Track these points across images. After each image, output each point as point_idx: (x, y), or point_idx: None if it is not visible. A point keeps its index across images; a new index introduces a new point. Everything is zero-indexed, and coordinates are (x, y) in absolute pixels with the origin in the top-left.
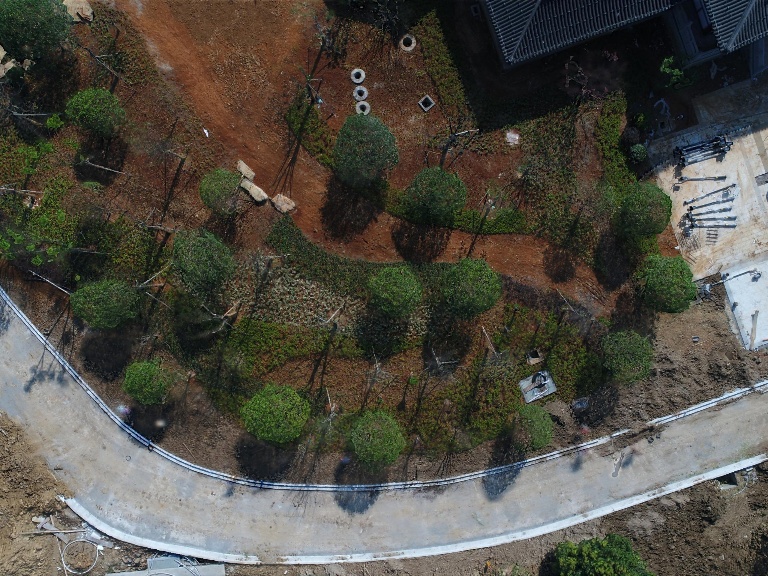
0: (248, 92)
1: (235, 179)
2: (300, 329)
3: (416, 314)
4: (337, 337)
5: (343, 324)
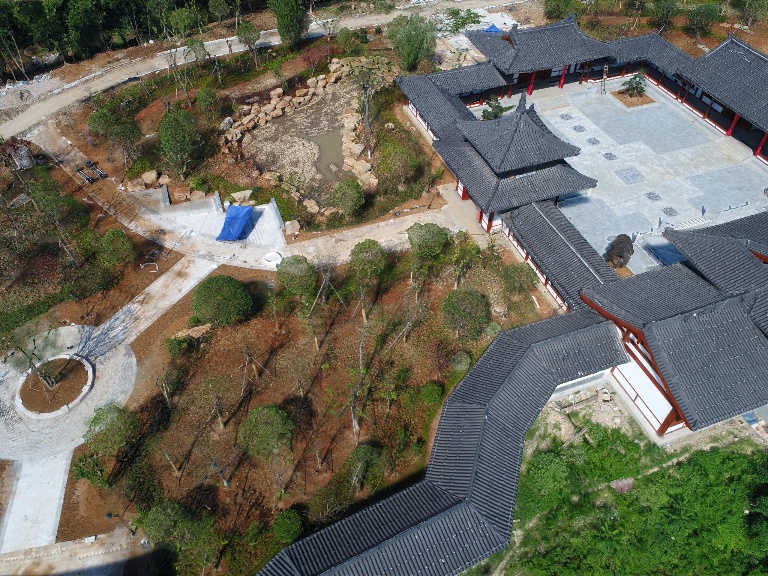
0: (763, 48)
1: (755, 2)
2: (698, 3)
3: (651, 6)
4: (681, 2)
5: (680, 4)
